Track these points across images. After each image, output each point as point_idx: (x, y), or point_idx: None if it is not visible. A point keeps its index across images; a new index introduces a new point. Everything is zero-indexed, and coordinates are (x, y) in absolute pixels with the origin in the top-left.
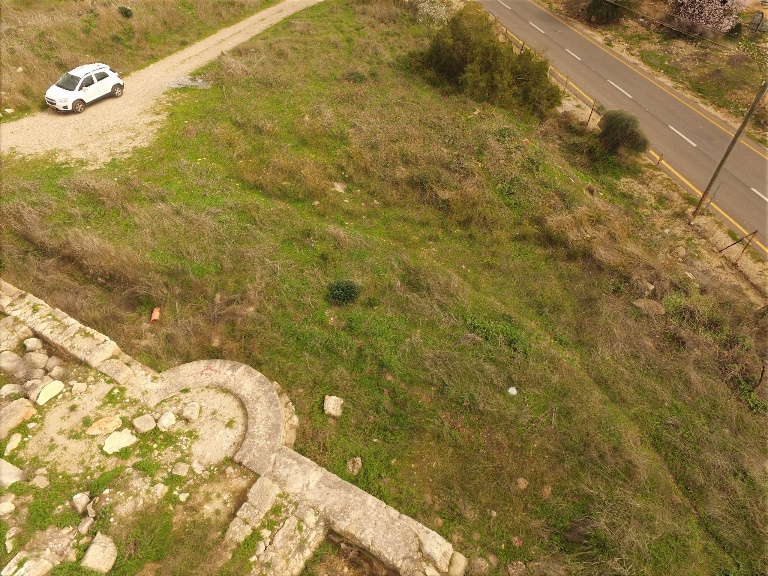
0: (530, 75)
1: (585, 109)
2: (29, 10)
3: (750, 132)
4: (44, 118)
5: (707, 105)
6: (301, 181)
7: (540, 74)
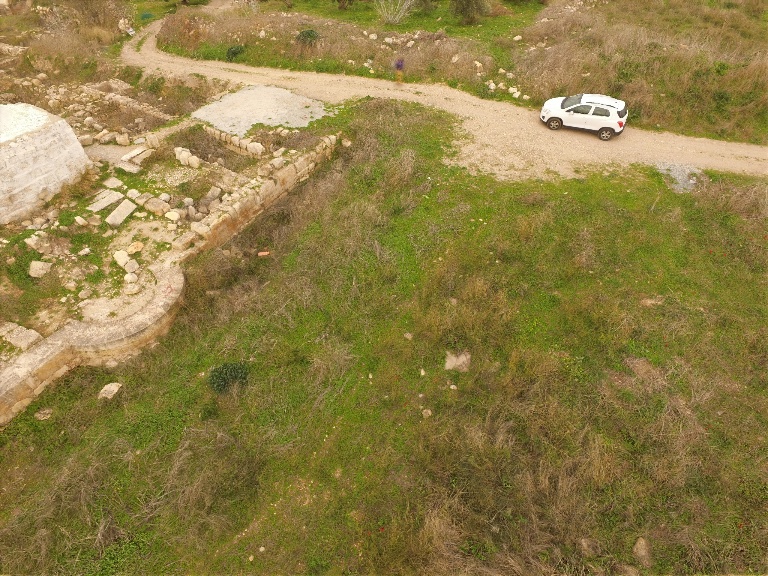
0: None
1: None
2: (754, 40)
3: None
4: (529, 116)
5: None
6: None
7: None
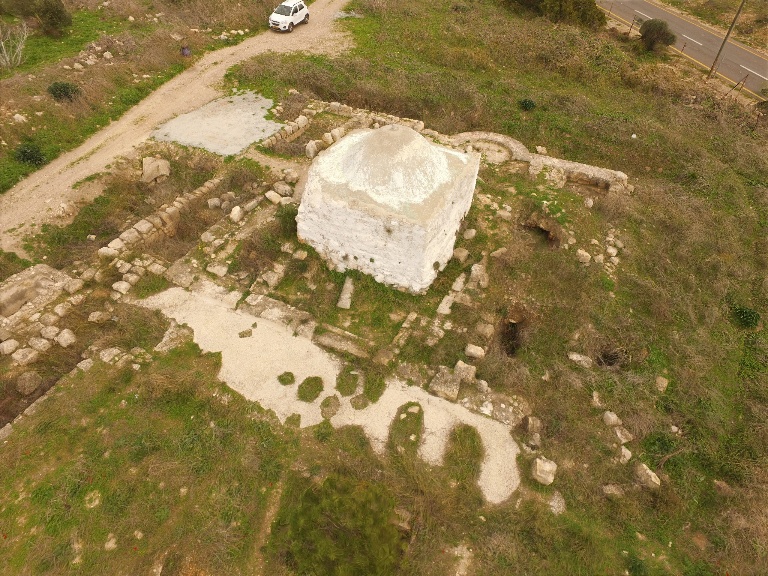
0: (585, 4)
1: (624, 26)
2: None
3: (736, 38)
4: (270, 35)
5: (705, 23)
6: (468, 61)
7: (591, 3)
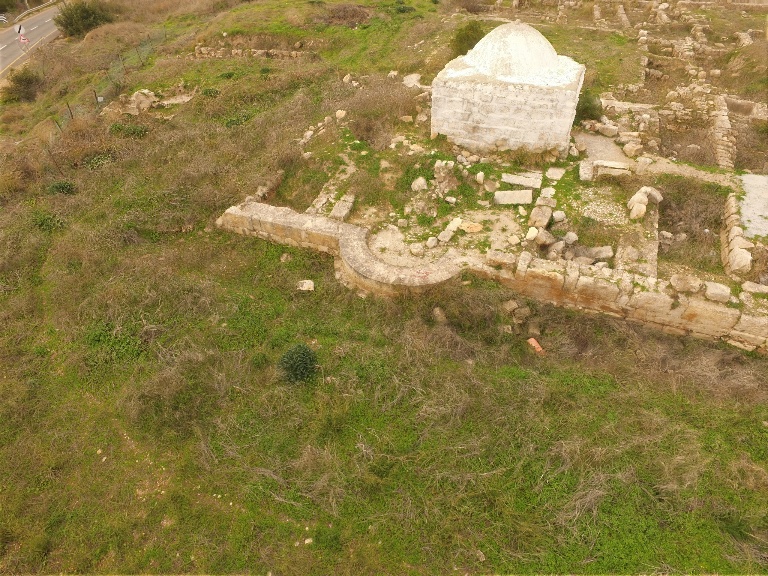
0: None
1: None
2: None
3: None
4: None
5: None
6: None
7: None
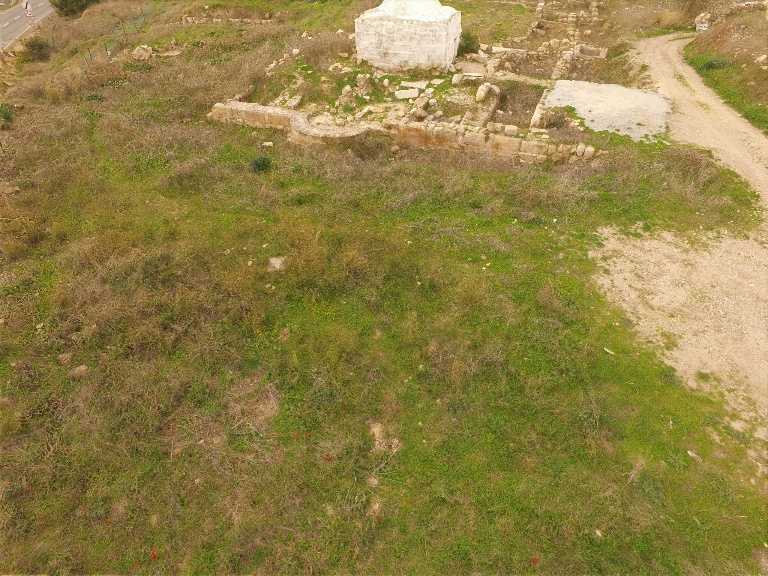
0: None
1: None
2: None
3: None
4: None
5: None
6: None
7: None
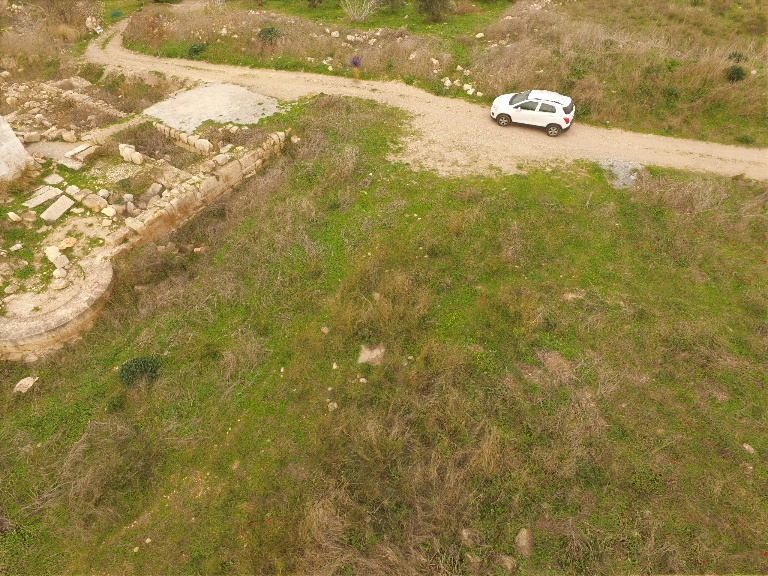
0: None
1: None
2: (715, 37)
3: None
4: (481, 113)
5: None
6: None
7: None
